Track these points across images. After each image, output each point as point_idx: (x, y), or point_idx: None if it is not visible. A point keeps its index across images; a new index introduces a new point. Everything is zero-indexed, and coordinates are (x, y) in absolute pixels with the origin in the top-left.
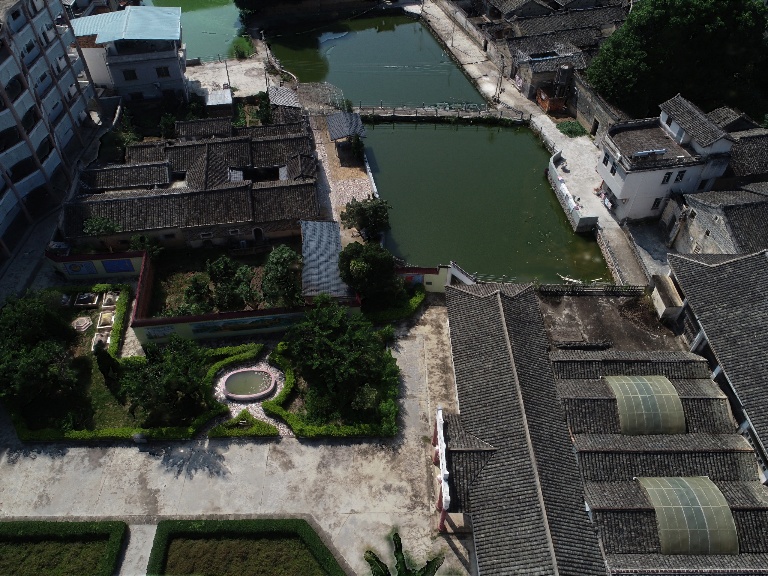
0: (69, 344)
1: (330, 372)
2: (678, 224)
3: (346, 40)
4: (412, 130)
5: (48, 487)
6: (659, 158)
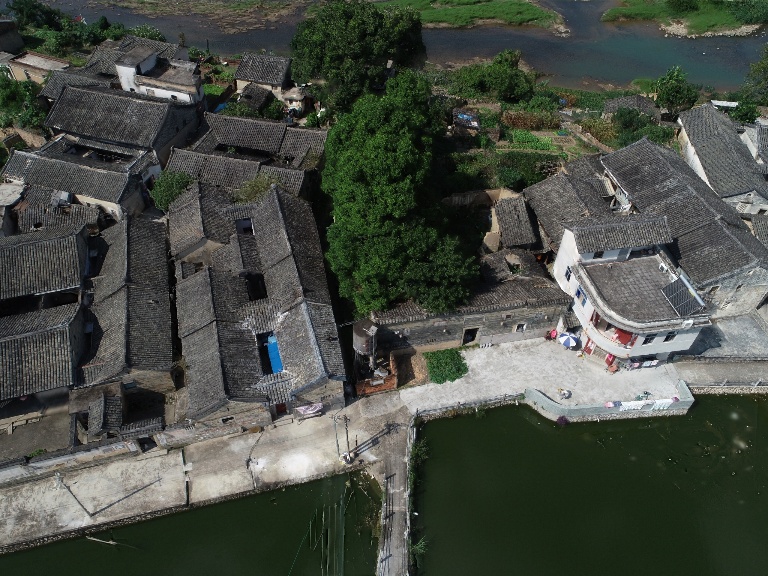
0: None
1: None
2: None
3: None
4: None
5: None
6: None
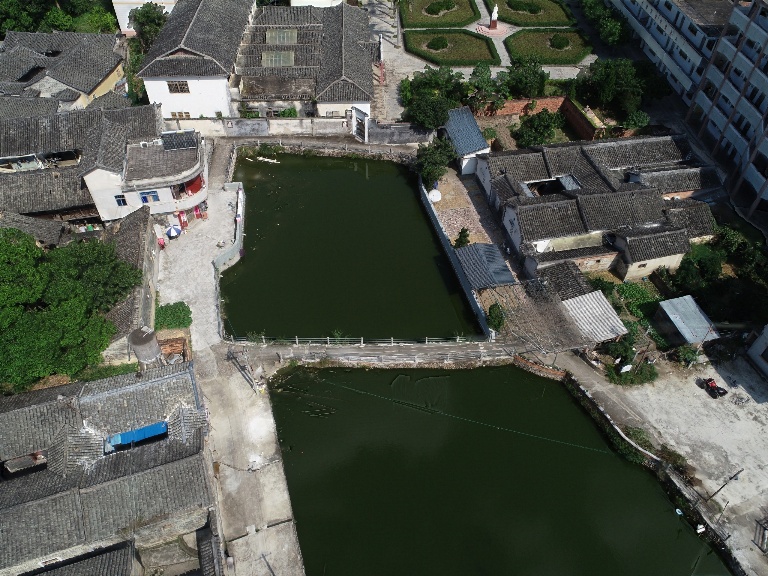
0: (608, 114)
1: None
2: None
3: None
4: None
5: (561, 73)
6: None
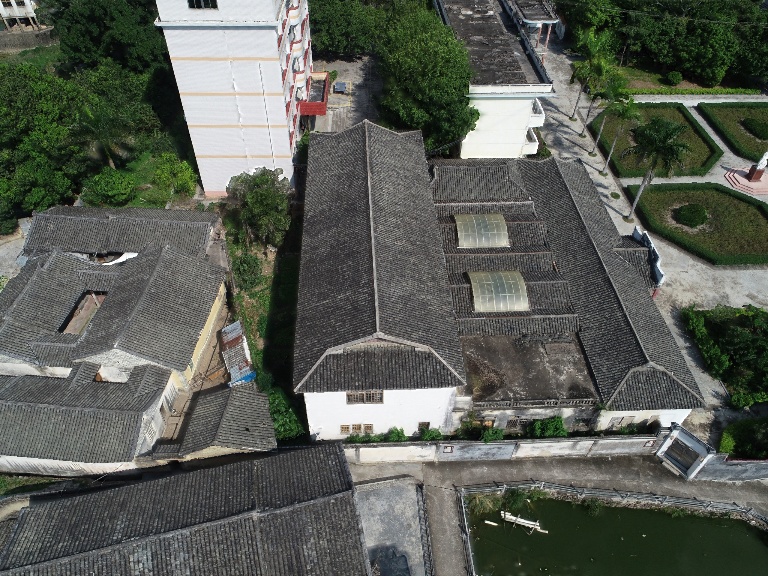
0: None
1: None
2: None
3: None
4: None
5: None
6: None
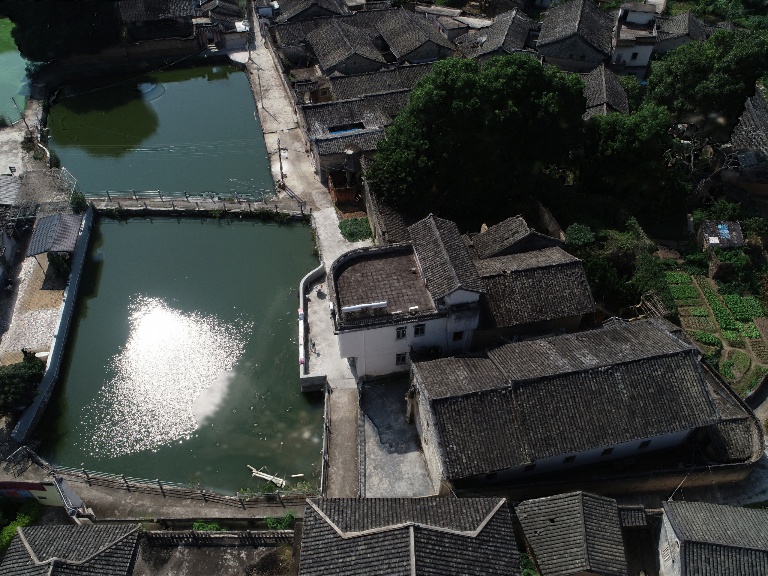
0: None
1: None
2: (407, 400)
3: (145, 99)
4: (175, 224)
5: None
6: (381, 312)
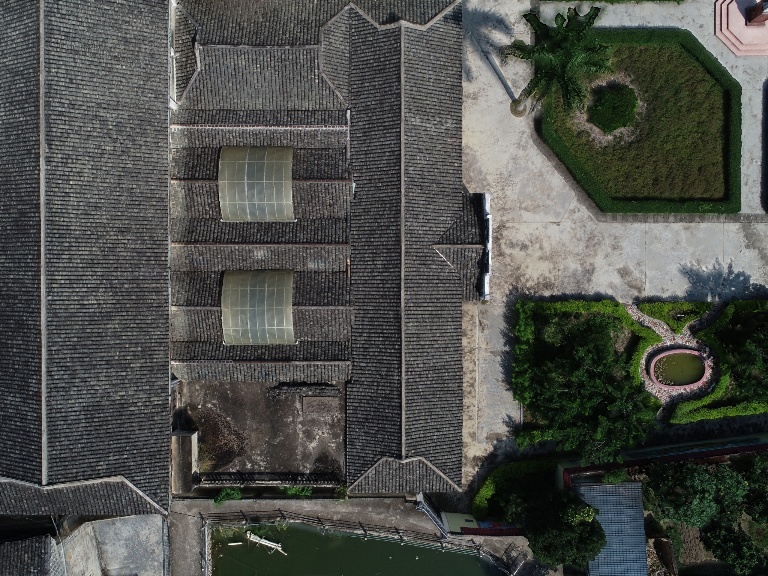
0: None
1: (603, 355)
2: None
3: None
4: None
5: None
6: None
